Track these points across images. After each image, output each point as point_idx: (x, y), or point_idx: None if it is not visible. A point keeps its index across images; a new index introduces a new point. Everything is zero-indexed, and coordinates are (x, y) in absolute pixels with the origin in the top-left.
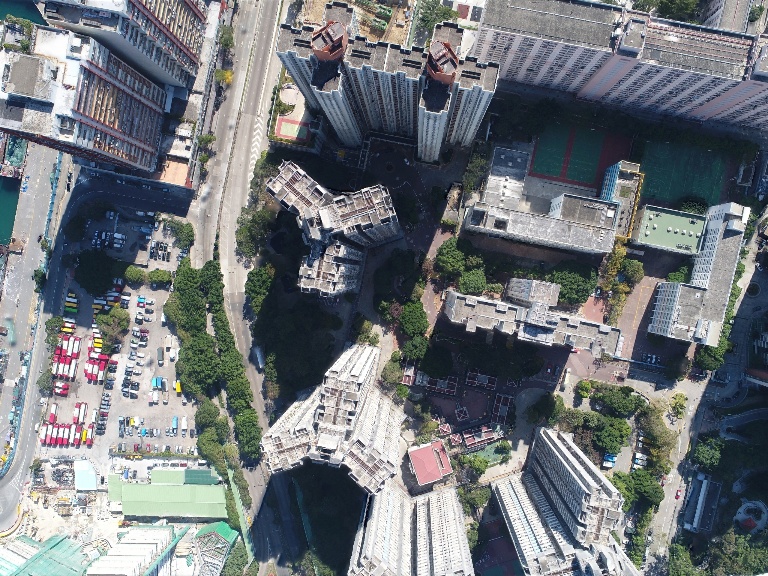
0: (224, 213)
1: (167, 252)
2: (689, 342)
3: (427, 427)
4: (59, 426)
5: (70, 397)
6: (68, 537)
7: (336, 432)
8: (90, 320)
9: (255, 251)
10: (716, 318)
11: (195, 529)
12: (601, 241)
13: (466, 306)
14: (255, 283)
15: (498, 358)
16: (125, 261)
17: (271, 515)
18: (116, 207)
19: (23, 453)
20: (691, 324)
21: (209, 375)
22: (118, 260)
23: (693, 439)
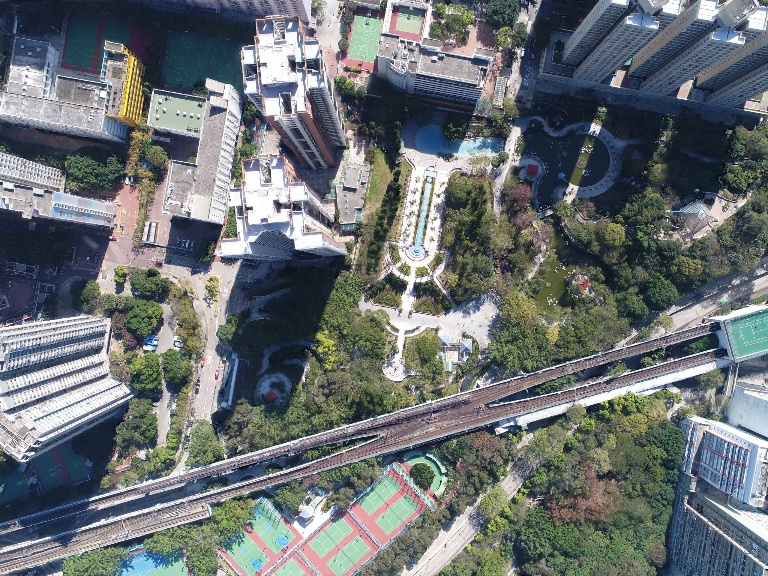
0: None
1: None
2: (218, 226)
3: None
4: None
5: None
6: None
7: None
8: None
9: None
10: (207, 193)
11: None
12: (91, 120)
13: None
14: None
15: (25, 244)
16: None
17: None
18: None
19: None
20: (184, 200)
21: None
22: None
23: None
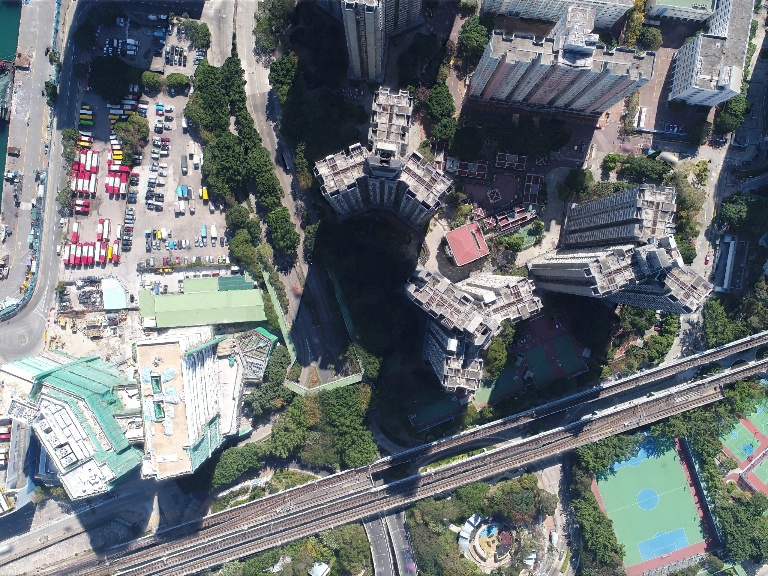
0: (239, 13)
1: (183, 56)
2: (708, 108)
3: (461, 209)
4: (82, 245)
5: (92, 215)
6: (100, 359)
7: (392, 142)
8: (107, 133)
9: (275, 46)
10: (737, 66)
11: (233, 338)
12: None
13: (503, 41)
14: (279, 72)
15: (527, 133)
16: (140, 67)
17: (309, 318)
18: (126, 13)
19: (46, 278)
20: (713, 74)
21: (238, 170)
22: (133, 66)
23: (718, 204)
